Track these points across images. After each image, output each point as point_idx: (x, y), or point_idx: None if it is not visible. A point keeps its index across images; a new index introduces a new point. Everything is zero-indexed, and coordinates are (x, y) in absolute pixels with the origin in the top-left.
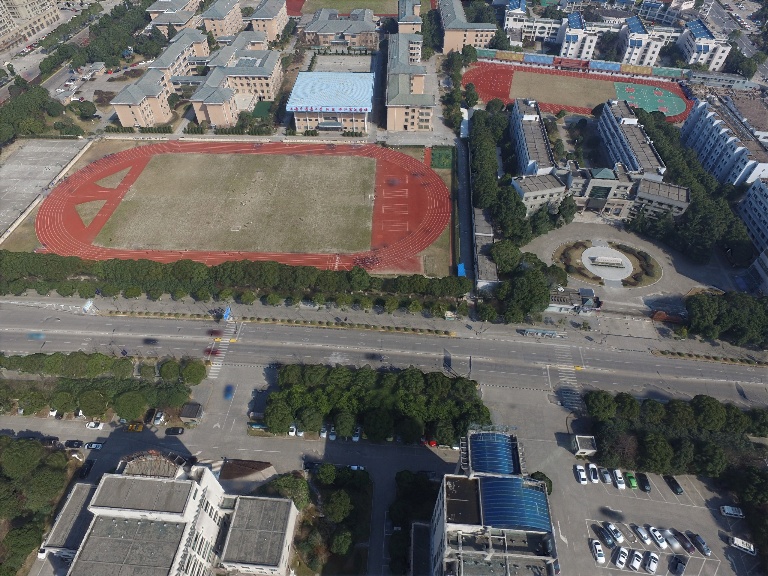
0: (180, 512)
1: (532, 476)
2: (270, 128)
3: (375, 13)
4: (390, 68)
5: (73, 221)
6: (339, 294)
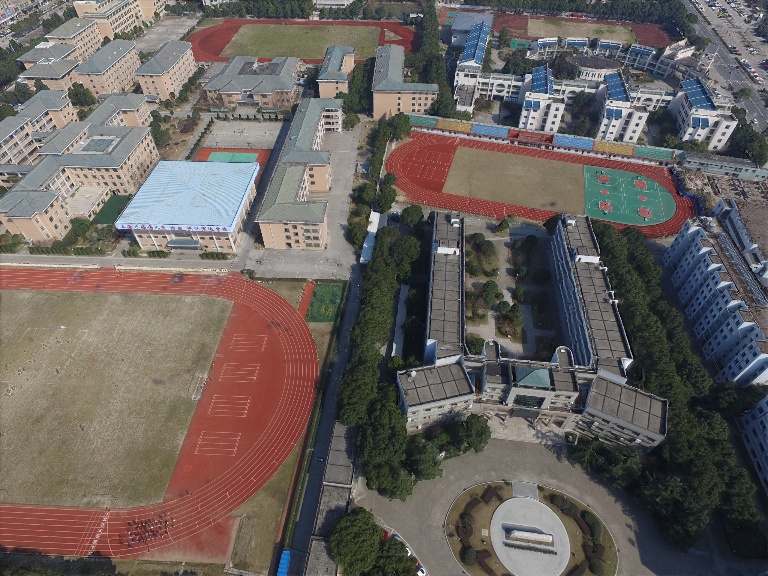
0: None
1: None
2: (108, 243)
3: (308, 58)
4: (282, 154)
5: None
6: None
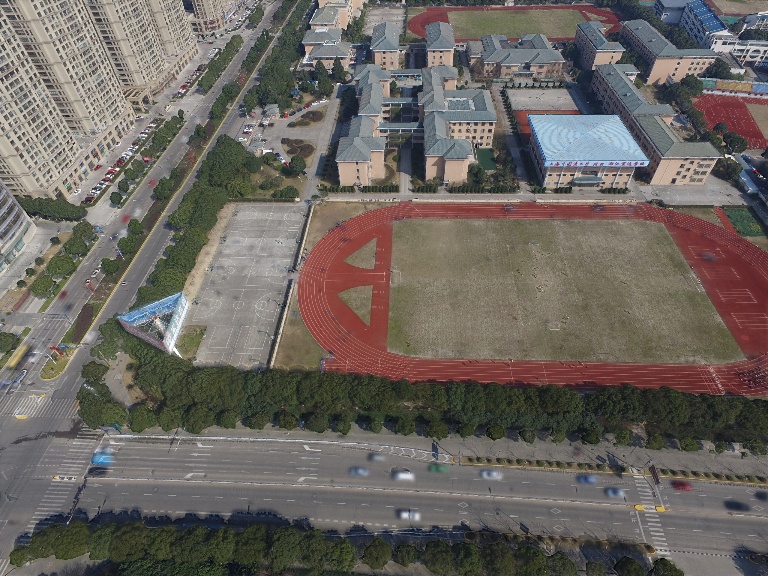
0: None
1: None
2: (509, 184)
3: None
4: (630, 108)
5: (348, 317)
6: (759, 432)
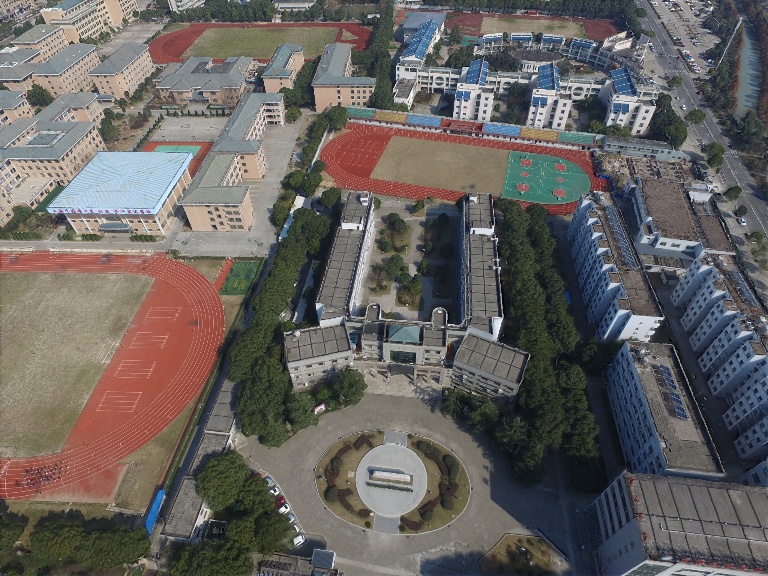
0: None
1: None
2: (46, 229)
3: (264, 58)
4: (215, 144)
5: None
6: None
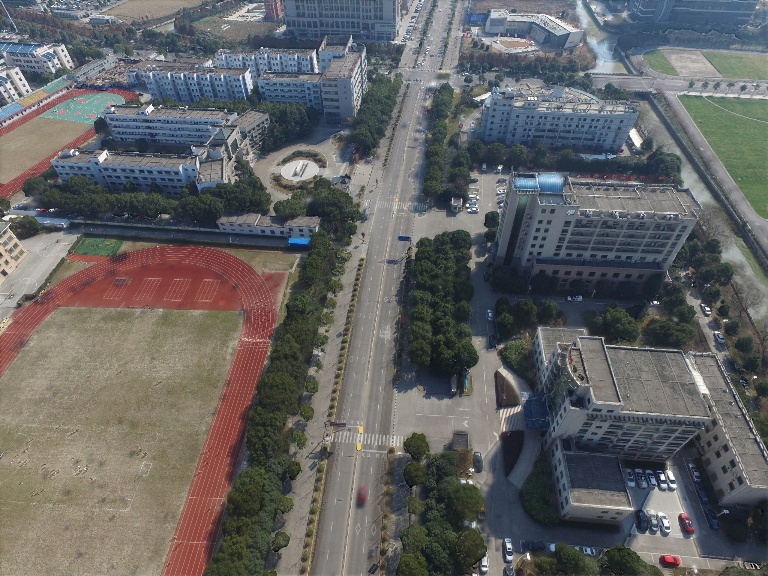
0: (601, 340)
1: (488, 219)
2: None
3: None
4: None
5: None
6: None
